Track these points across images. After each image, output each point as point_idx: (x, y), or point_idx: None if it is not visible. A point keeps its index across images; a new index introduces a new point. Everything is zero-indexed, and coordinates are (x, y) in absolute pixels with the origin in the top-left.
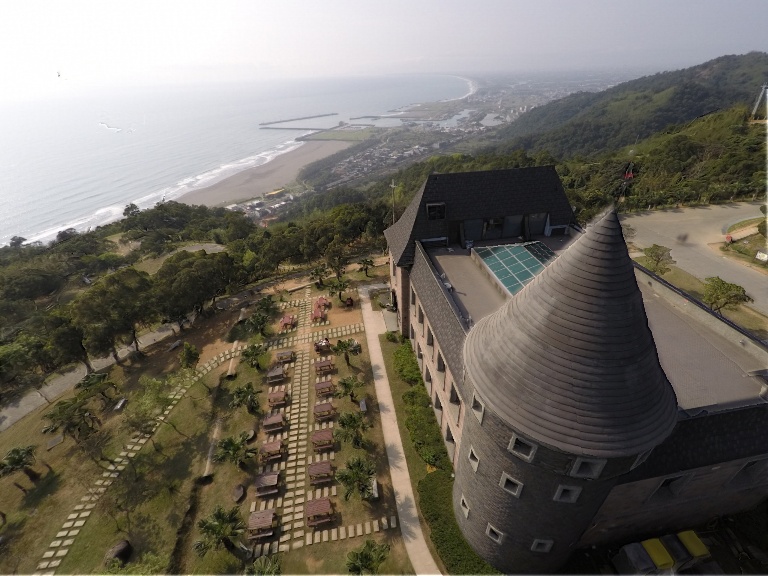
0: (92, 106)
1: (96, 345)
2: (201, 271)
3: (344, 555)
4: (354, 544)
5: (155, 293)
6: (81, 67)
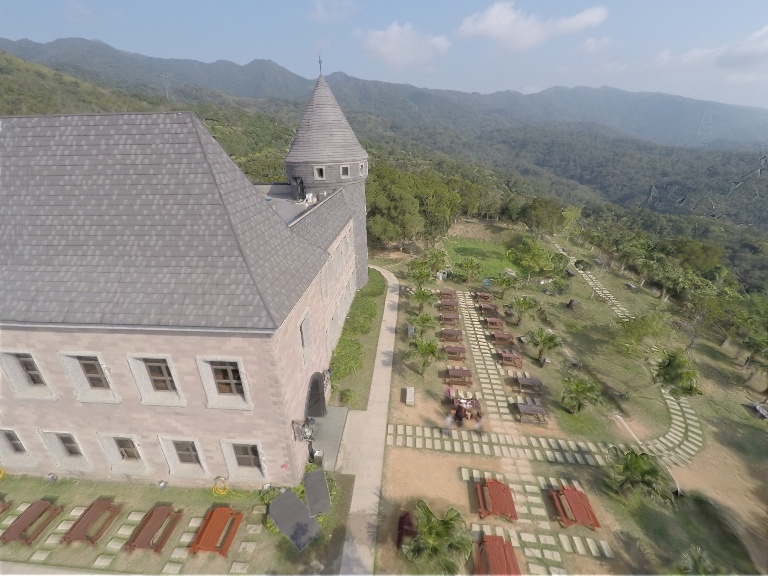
0: None
1: None
2: None
3: (432, 286)
4: (427, 288)
5: None
6: None
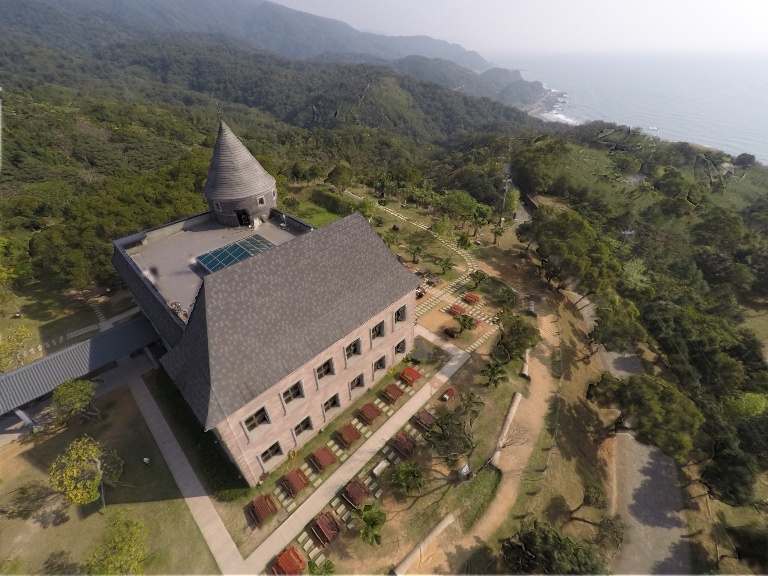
0: None
1: None
2: (549, 246)
3: None
4: None
5: None
6: None
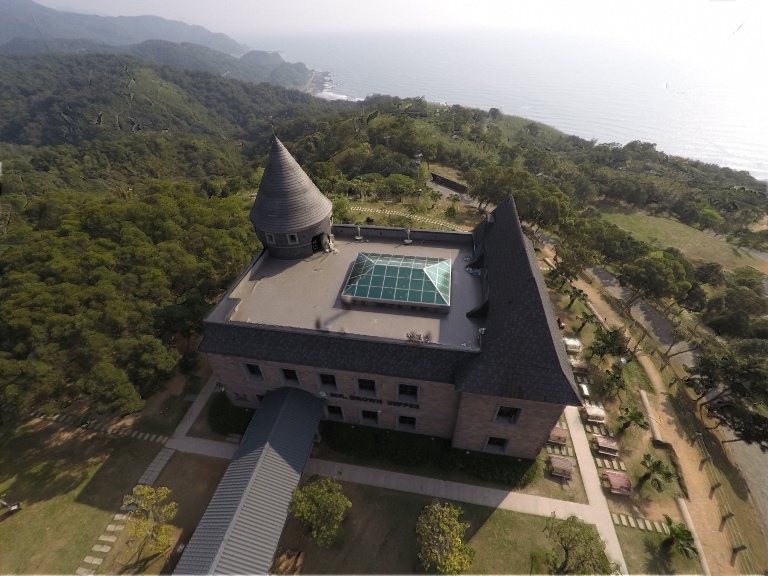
0: (701, 63)
1: (474, 189)
2: (526, 195)
3: None
4: None
5: (513, 191)
6: (761, 21)
